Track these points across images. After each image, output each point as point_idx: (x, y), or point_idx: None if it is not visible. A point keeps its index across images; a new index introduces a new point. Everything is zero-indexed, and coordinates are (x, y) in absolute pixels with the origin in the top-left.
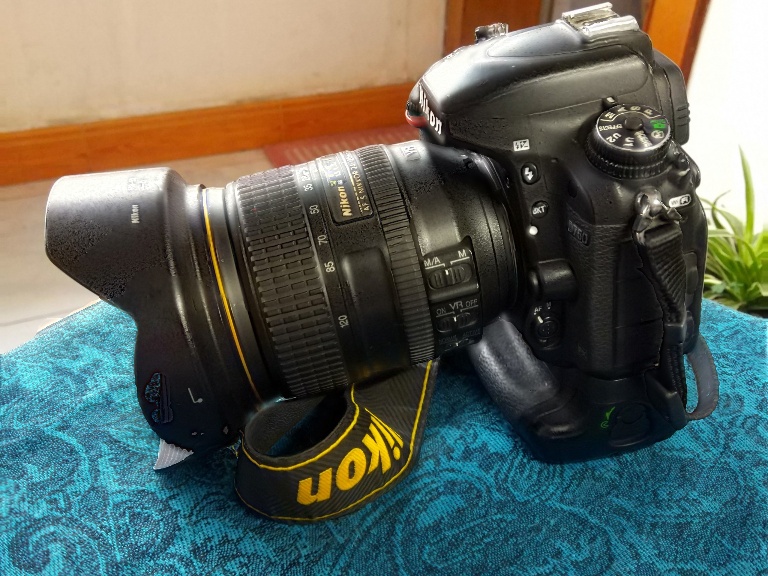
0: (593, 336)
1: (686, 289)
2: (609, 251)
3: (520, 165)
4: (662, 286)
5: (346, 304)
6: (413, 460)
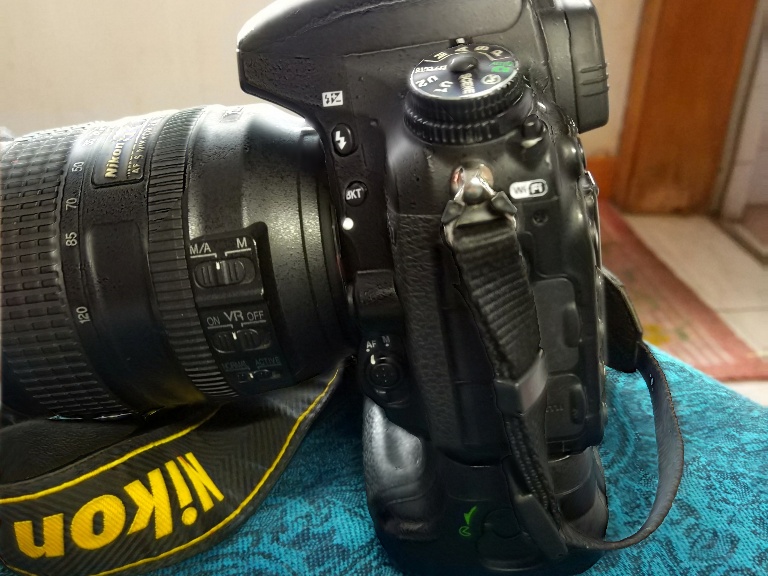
0: (425, 390)
1: (563, 337)
2: (423, 256)
3: (331, 127)
4: (481, 315)
5: (86, 291)
6: (223, 531)
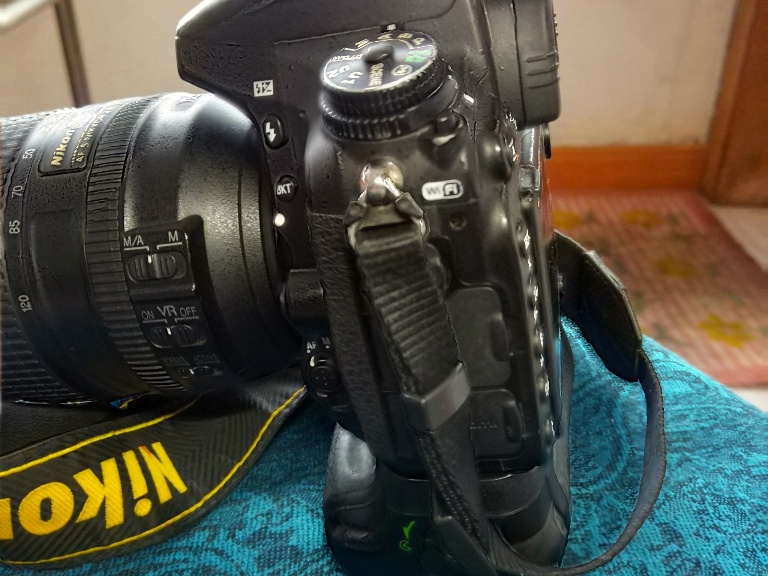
0: (353, 397)
1: (492, 350)
2: (337, 258)
3: (263, 118)
4: (385, 325)
5: (27, 280)
6: (180, 524)
